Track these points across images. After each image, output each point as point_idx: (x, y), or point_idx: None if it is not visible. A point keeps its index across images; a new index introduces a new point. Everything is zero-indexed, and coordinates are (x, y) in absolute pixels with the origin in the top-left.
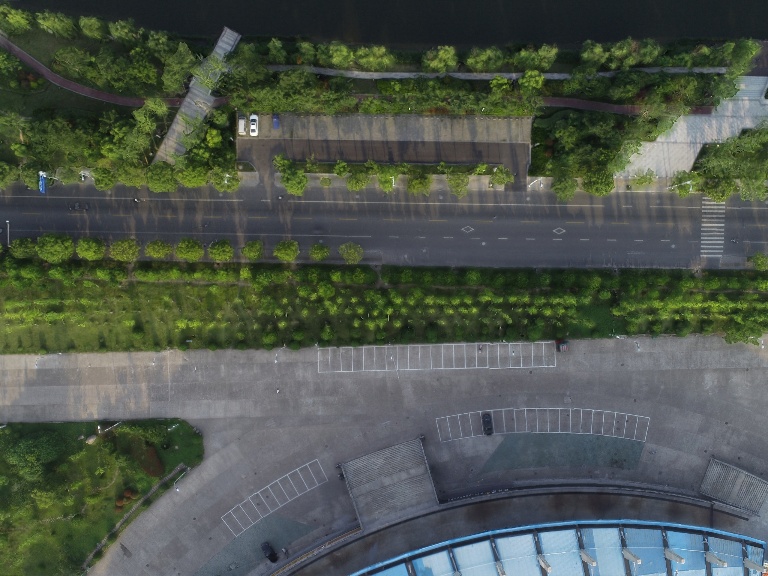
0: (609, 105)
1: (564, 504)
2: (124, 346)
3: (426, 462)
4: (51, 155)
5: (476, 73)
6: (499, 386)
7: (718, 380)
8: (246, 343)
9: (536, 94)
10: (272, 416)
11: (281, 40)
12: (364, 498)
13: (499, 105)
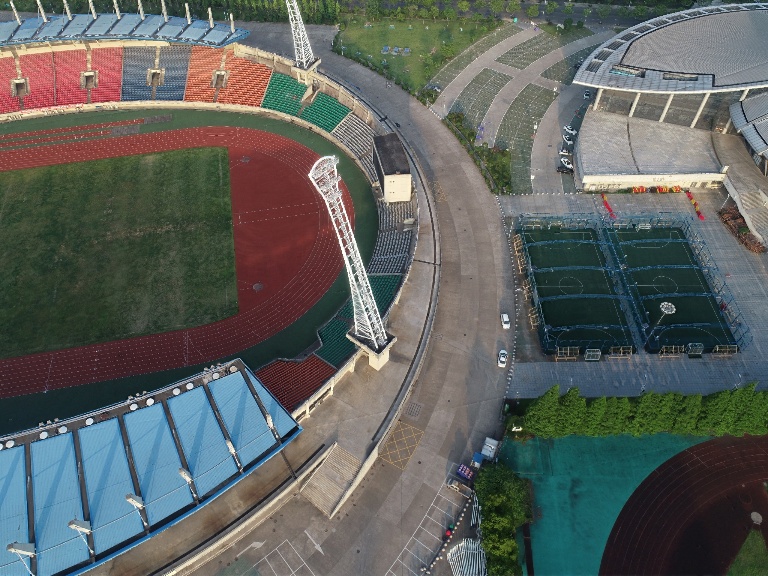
0: None
1: None
2: None
3: None
4: None
5: None
6: None
7: (276, 35)
8: (36, 10)
9: None
10: None
11: None
12: None
13: None
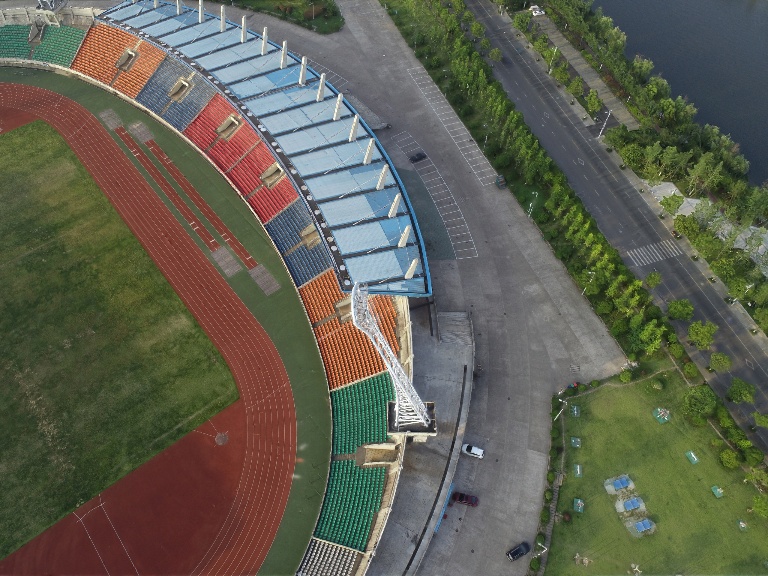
0: None
1: None
2: None
3: (376, 124)
4: None
5: None
6: (449, 158)
7: (538, 295)
8: (408, 36)
9: (660, 126)
10: (367, 57)
11: None
12: None
13: None
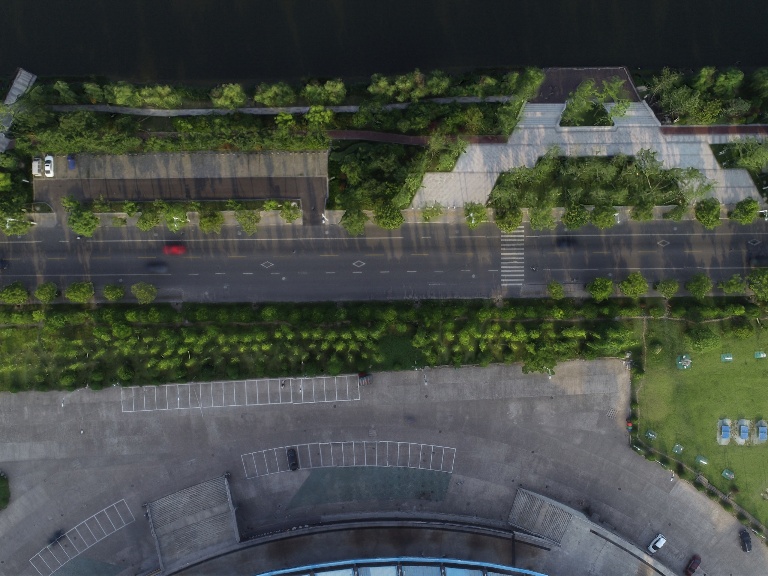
0: (405, 137)
1: (365, 539)
2: None
3: (228, 500)
4: None
5: (273, 108)
6: (303, 421)
7: (523, 409)
8: (48, 385)
9: (331, 128)
10: (77, 457)
11: (74, 80)
12: (167, 538)
13: (288, 141)
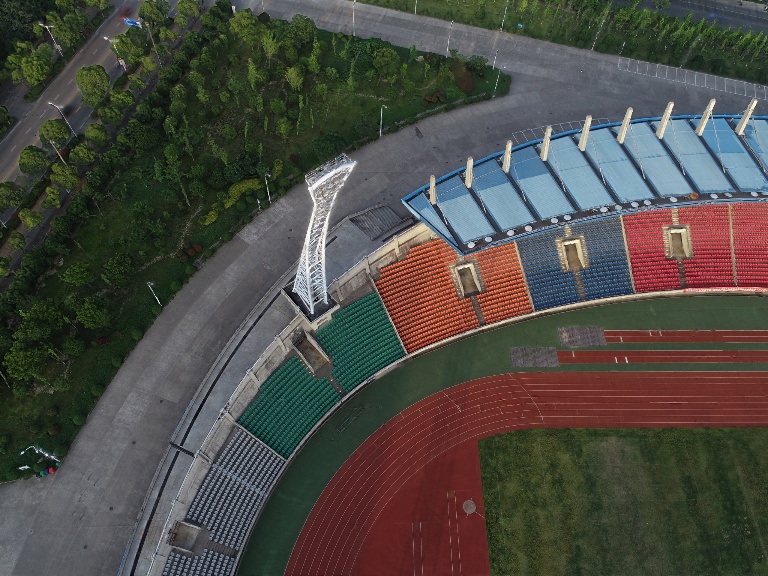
0: None
1: None
2: (465, 21)
3: None
4: None
5: None
6: None
7: None
8: (562, 40)
9: None
10: (573, 84)
11: None
12: None
13: None
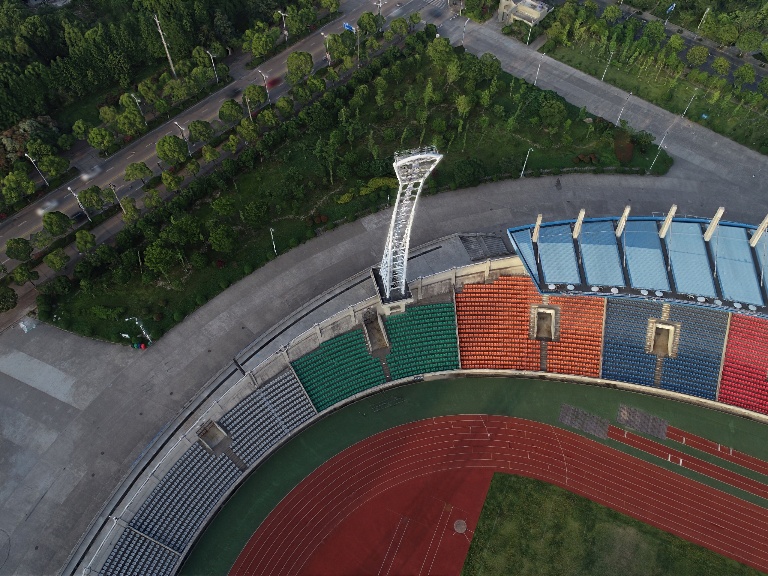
0: None
1: None
2: (649, 99)
3: None
4: (680, 8)
5: None
6: None
7: None
8: (745, 141)
9: None
10: (739, 185)
11: None
12: None
13: None
